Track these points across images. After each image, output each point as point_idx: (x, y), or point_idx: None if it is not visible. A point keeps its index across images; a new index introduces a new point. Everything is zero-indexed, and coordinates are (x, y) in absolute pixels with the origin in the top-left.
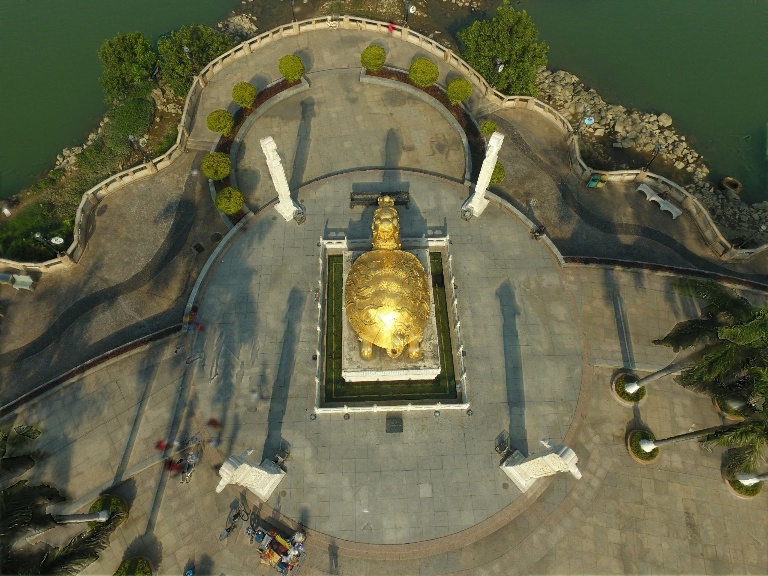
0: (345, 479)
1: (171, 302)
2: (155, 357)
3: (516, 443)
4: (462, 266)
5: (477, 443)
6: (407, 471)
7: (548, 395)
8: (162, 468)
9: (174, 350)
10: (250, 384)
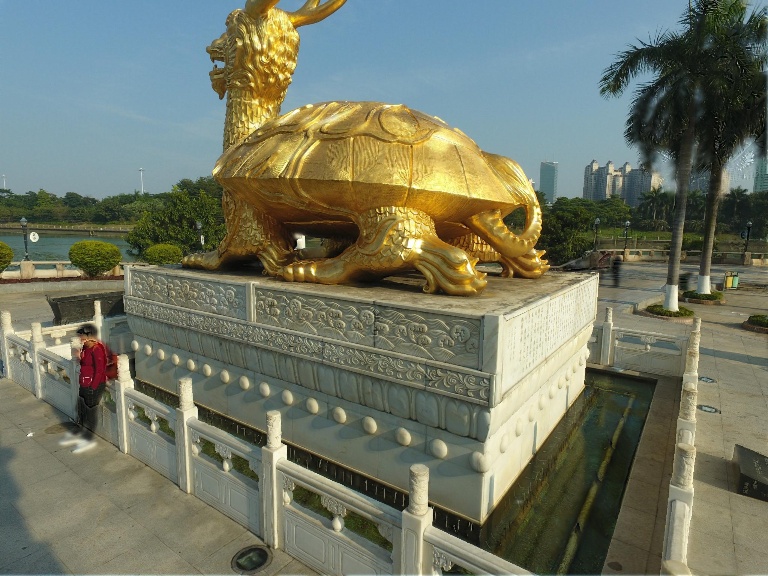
0: None
1: None
2: None
3: None
4: None
5: None
6: None
7: (671, 332)
8: None
9: None
10: None
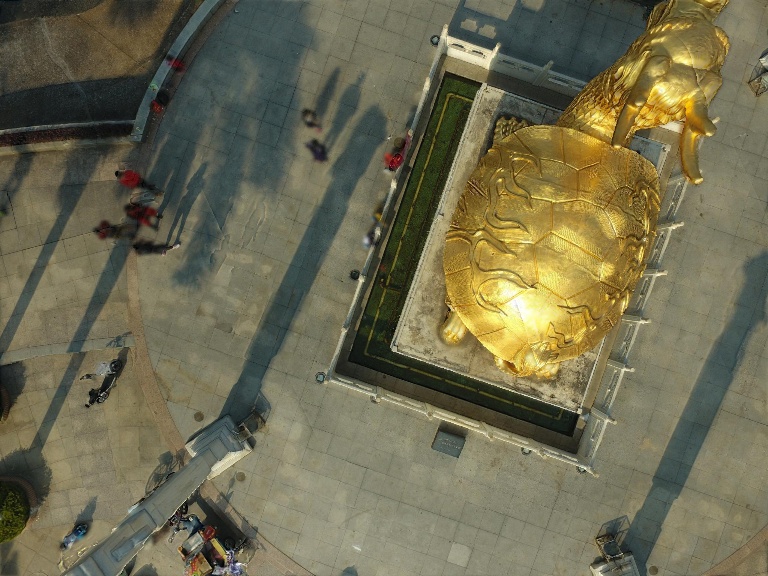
0: (341, 492)
1: (132, 64)
2: (79, 170)
3: (634, 542)
4: (698, 193)
5: (571, 519)
6: (442, 517)
7: (729, 490)
8: (67, 363)
9: (114, 169)
10: (231, 282)
